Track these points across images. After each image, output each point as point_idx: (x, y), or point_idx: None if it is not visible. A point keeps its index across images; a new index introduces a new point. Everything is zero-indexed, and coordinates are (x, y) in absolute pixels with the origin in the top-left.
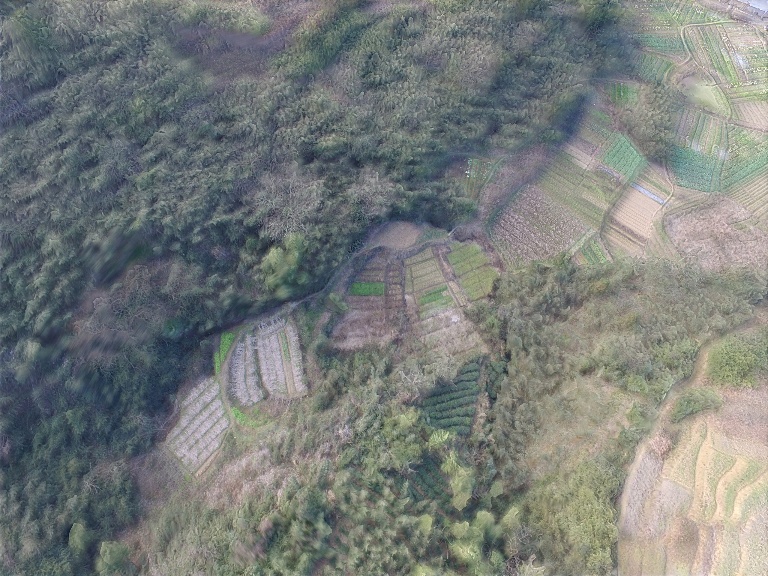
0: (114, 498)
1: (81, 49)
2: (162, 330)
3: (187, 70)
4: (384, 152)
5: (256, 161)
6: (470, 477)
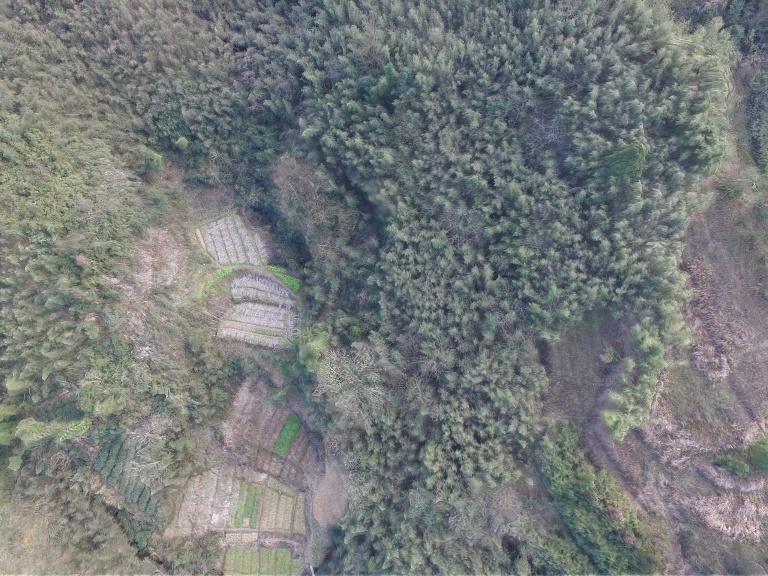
0: (203, 170)
1: (612, 218)
2: (309, 231)
3: (585, 329)
4: (403, 532)
5: (432, 367)
6: (32, 443)
